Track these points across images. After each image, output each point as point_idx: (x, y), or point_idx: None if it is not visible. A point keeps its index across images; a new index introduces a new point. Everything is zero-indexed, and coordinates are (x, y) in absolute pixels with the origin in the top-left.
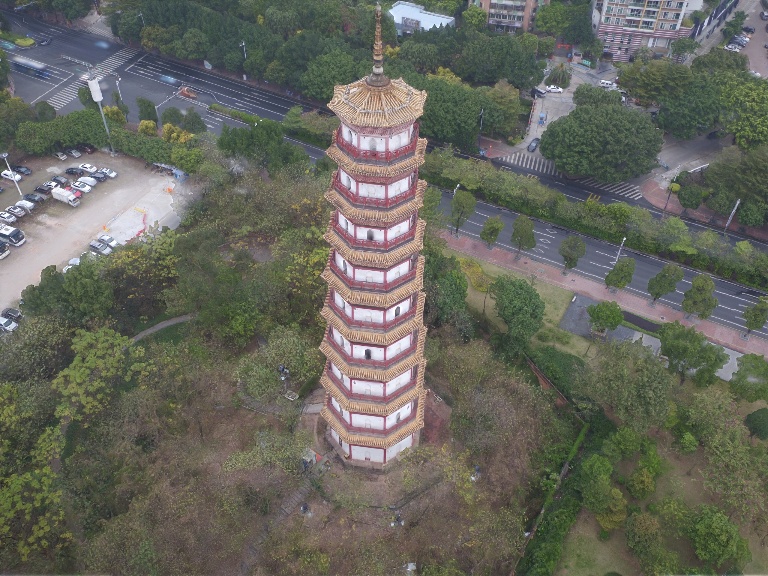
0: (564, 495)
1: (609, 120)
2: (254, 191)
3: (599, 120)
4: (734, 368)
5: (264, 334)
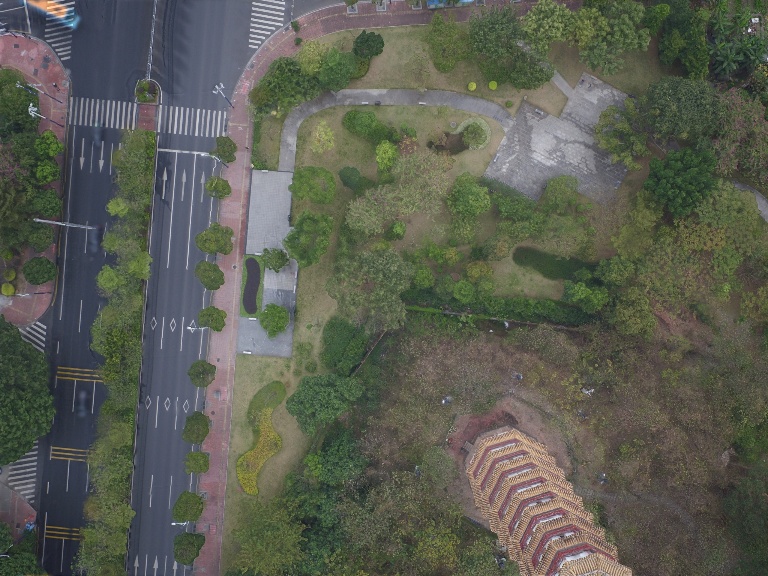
0: None
1: None
2: None
3: None
4: (273, 198)
5: None
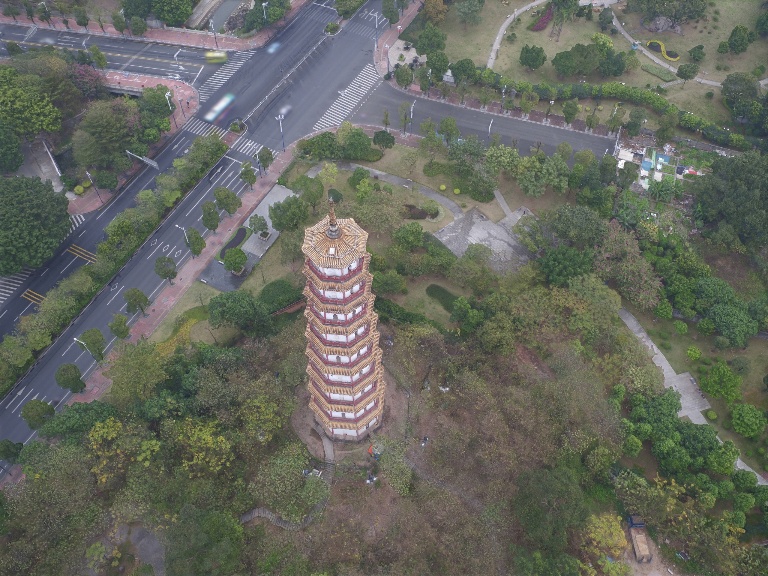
0: (380, 308)
1: (7, 205)
2: (30, 550)
3: (6, 212)
4: None
5: (244, 510)
